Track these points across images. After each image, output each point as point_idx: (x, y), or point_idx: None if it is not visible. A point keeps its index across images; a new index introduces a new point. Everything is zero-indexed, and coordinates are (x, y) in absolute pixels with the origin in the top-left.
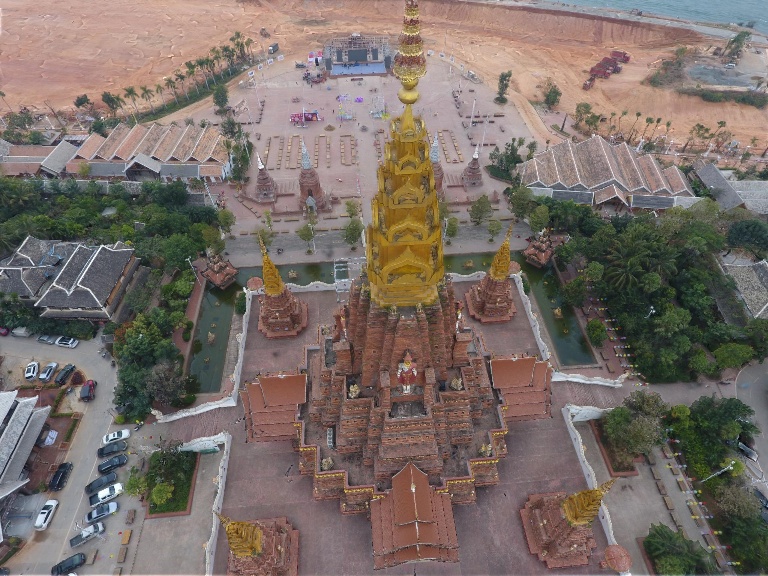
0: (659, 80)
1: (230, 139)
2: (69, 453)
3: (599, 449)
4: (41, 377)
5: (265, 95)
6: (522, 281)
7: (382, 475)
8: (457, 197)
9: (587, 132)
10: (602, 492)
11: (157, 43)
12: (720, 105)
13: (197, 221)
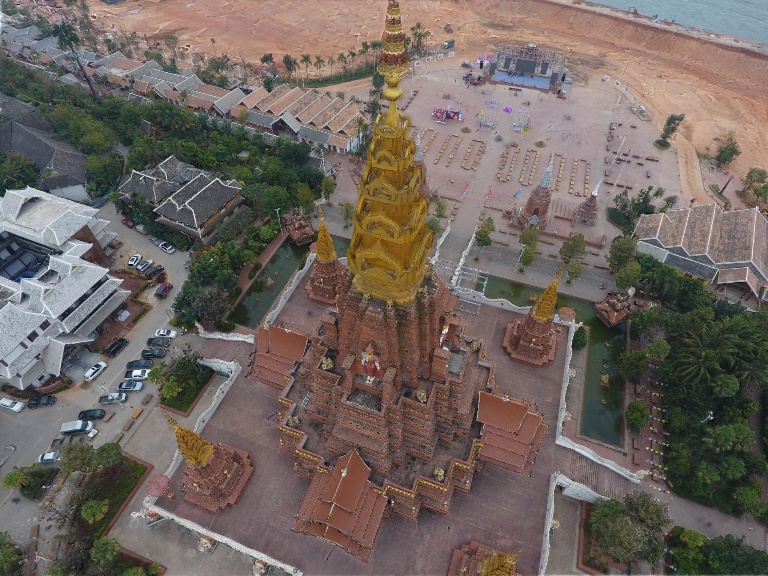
0: None
1: (371, 118)
2: (130, 333)
3: (578, 534)
4: (138, 268)
5: (421, 86)
6: (579, 333)
7: (333, 452)
8: (558, 229)
9: (753, 203)
10: (508, 560)
11: (352, 21)
12: None
13: None
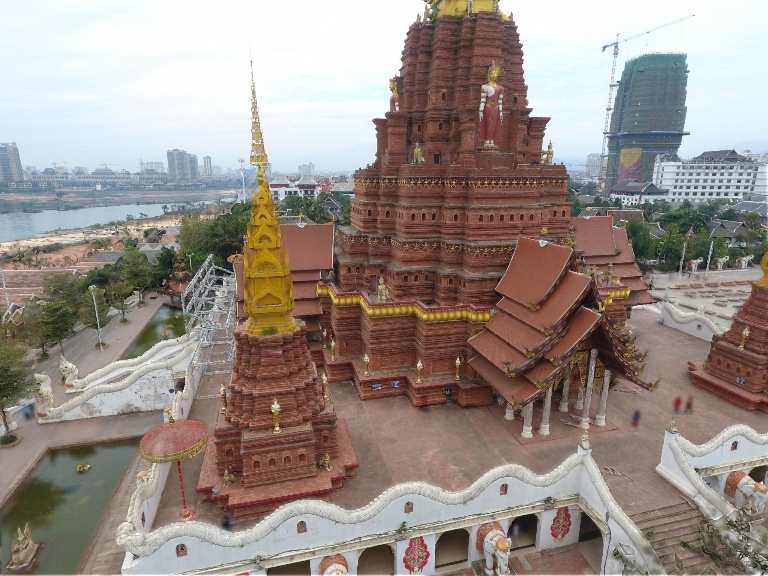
0: None
1: None
2: None
3: None
4: None
5: None
6: None
7: None
8: None
9: None
10: None
11: None
12: None
13: None
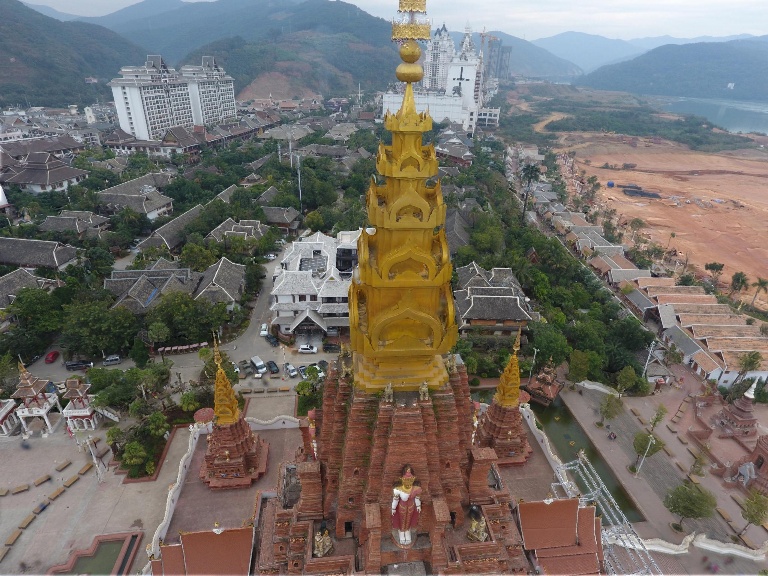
0: None
1: None
2: None
3: None
4: None
5: None
6: None
7: None
8: None
9: None
10: None
11: None
12: None
13: (619, 368)
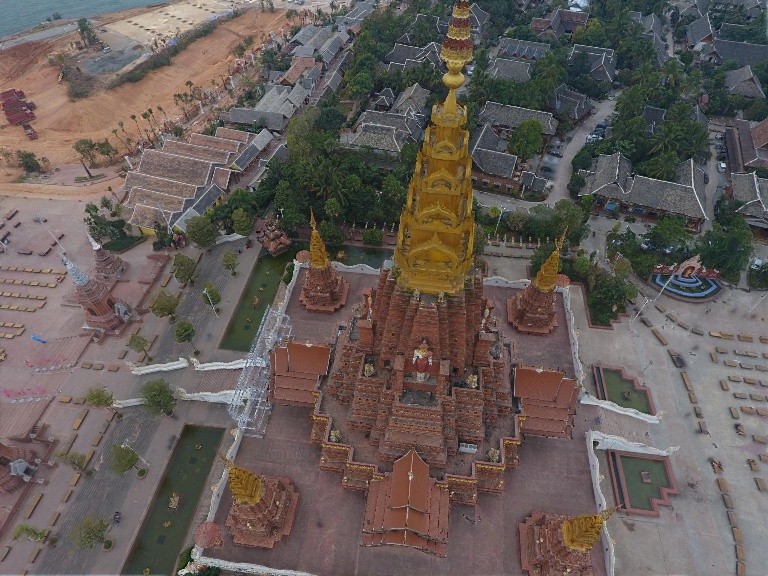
0: (81, 90)
1: None
2: None
3: None
4: None
5: None
6: None
7: None
8: None
9: (111, 161)
10: None
11: None
12: (148, 79)
13: None
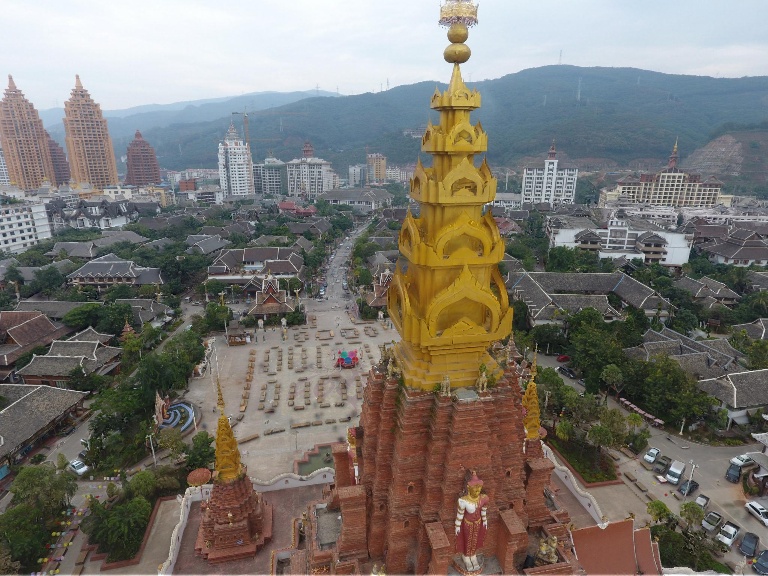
0: None
1: None
2: None
3: None
4: None
5: None
6: None
7: None
8: None
9: None
10: None
11: None
12: None
13: None
